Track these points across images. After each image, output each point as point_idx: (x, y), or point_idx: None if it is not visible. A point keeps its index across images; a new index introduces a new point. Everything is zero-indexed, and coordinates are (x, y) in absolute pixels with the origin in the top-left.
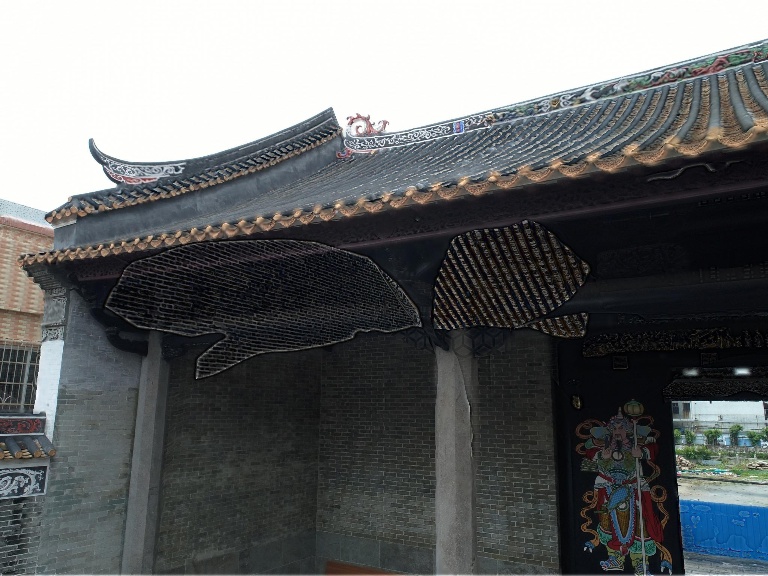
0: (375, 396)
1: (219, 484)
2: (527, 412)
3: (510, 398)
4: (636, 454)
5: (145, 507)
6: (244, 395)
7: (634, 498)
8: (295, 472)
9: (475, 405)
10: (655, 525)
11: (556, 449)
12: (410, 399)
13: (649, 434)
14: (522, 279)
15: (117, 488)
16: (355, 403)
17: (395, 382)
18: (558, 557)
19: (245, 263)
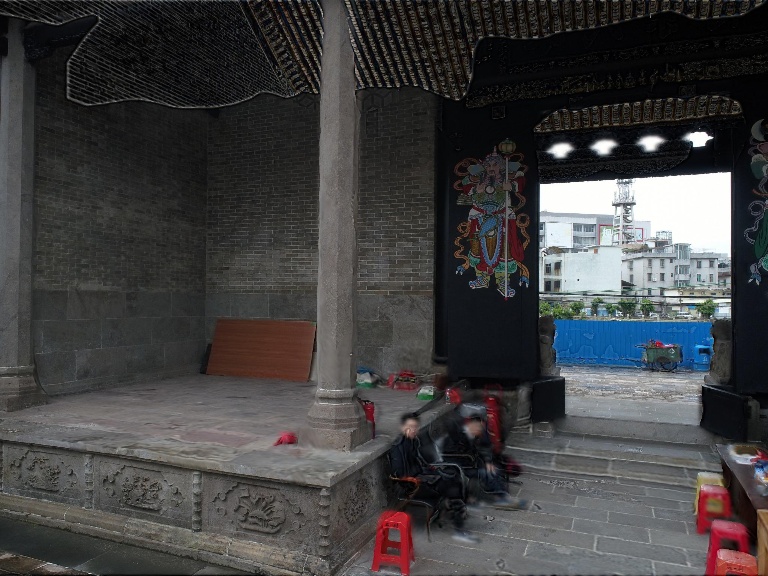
0: (264, 159)
1: (100, 221)
2: (411, 159)
3: (396, 148)
4: (506, 187)
5: (18, 212)
6: (124, 138)
7: (502, 226)
8: (182, 232)
9: (363, 158)
10: (518, 248)
11: (436, 190)
12: (299, 158)
13: (519, 169)
14: (413, 70)
15: None
16: (243, 167)
17: (284, 143)
18: (433, 285)
19: (118, 5)
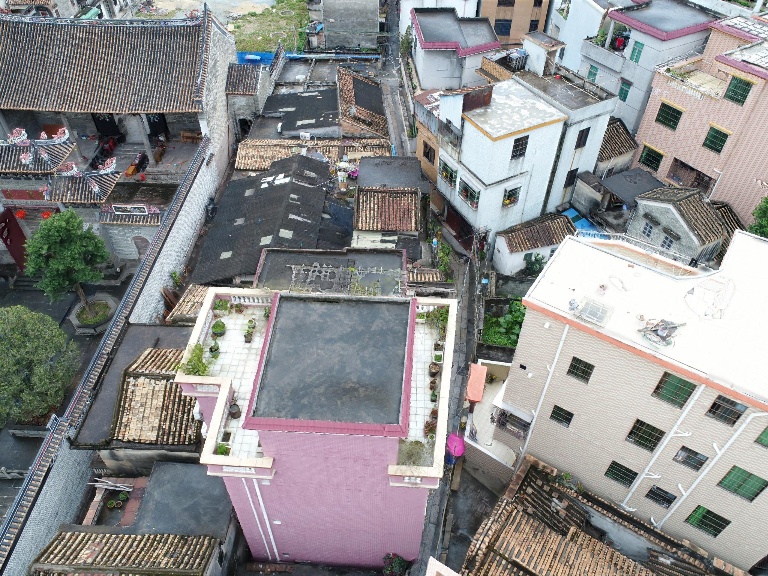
0: None
1: None
2: None
3: None
4: None
5: None
6: None
7: None
8: None
9: None
10: None
11: None
12: None
13: None
14: None
15: (3, 132)
16: None
17: None
18: (92, 118)
19: None
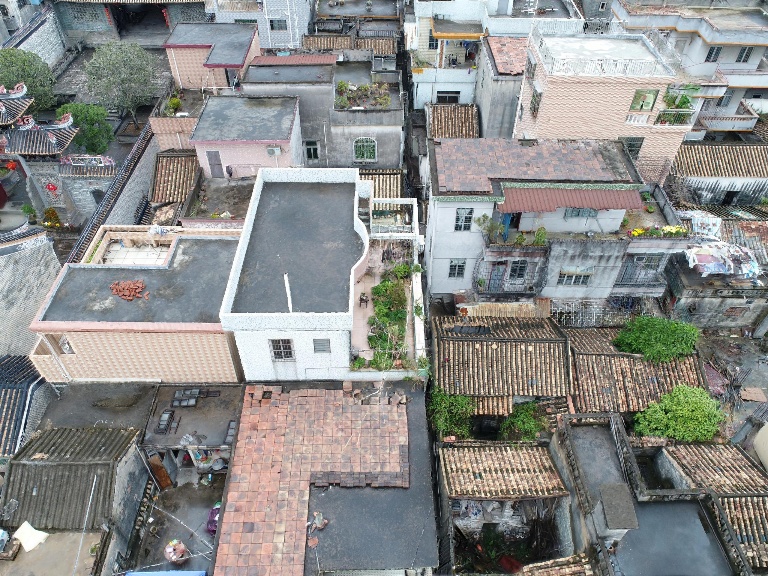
0: None
1: None
2: None
3: None
4: None
5: None
6: None
7: None
8: None
9: None
10: None
11: None
12: None
13: None
14: None
15: None
16: None
17: None
18: None
19: (8, 281)
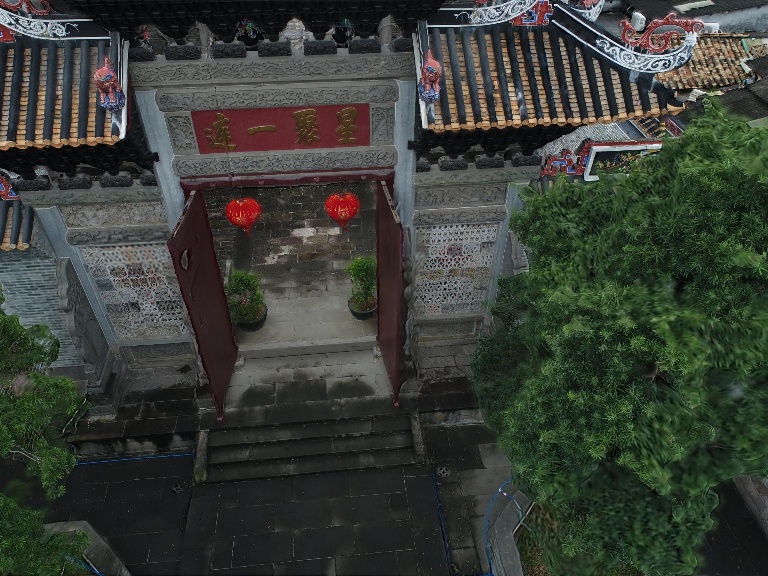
0: None
1: None
2: None
3: None
4: None
5: None
6: None
7: None
8: None
9: None
10: None
11: None
12: None
13: None
14: None
15: None
16: None
17: None
18: None
19: None
